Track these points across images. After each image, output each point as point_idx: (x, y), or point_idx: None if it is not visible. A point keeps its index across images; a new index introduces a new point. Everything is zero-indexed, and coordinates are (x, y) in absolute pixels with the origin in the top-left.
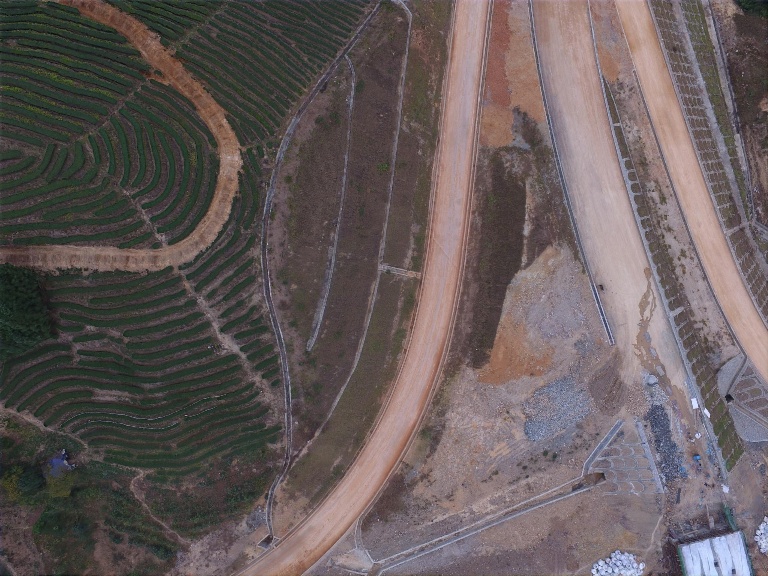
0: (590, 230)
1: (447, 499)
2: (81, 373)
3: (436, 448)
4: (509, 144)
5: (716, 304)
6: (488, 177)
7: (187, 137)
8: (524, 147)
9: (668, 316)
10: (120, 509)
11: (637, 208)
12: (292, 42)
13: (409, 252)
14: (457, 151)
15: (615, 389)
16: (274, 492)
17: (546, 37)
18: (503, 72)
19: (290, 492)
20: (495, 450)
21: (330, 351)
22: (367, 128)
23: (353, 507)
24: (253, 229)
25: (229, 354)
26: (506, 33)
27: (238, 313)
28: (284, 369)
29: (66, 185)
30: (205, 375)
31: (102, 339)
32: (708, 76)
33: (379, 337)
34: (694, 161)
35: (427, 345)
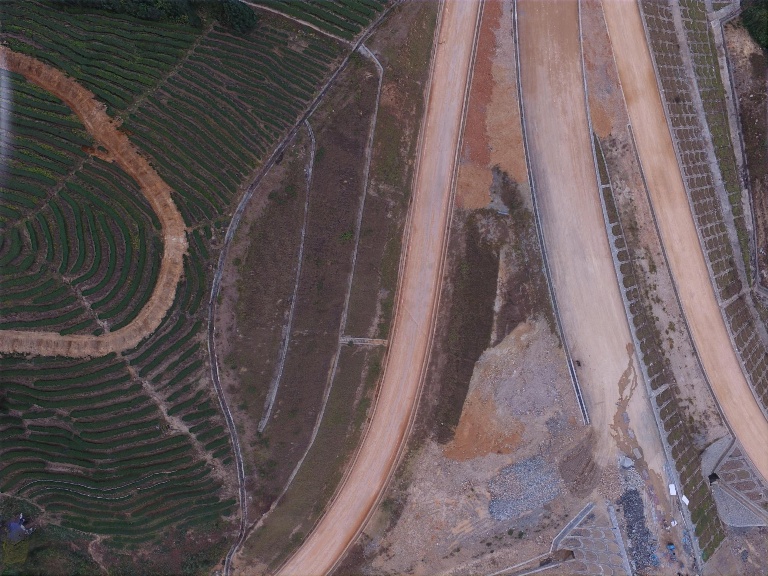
0: (570, 301)
1: (406, 573)
2: (33, 446)
3: (396, 523)
4: (486, 206)
5: (705, 381)
6: (462, 241)
7: (130, 219)
8: (502, 210)
9: (649, 396)
10: (79, 570)
11: (623, 278)
12: (249, 106)
13: (375, 320)
14: (431, 212)
15: (587, 471)
16: (230, 559)
17: (533, 88)
18: (484, 127)
19: (247, 559)
20: (457, 527)
21: (284, 430)
22: (328, 197)
23: (311, 574)
24: (199, 313)
25: (178, 434)
26: (489, 84)
27: (185, 397)
28: (236, 448)
29: (3, 273)
30: (155, 452)
31: (51, 416)
32: (716, 126)
33: (340, 410)
34: (690, 226)
35: (392, 415)
